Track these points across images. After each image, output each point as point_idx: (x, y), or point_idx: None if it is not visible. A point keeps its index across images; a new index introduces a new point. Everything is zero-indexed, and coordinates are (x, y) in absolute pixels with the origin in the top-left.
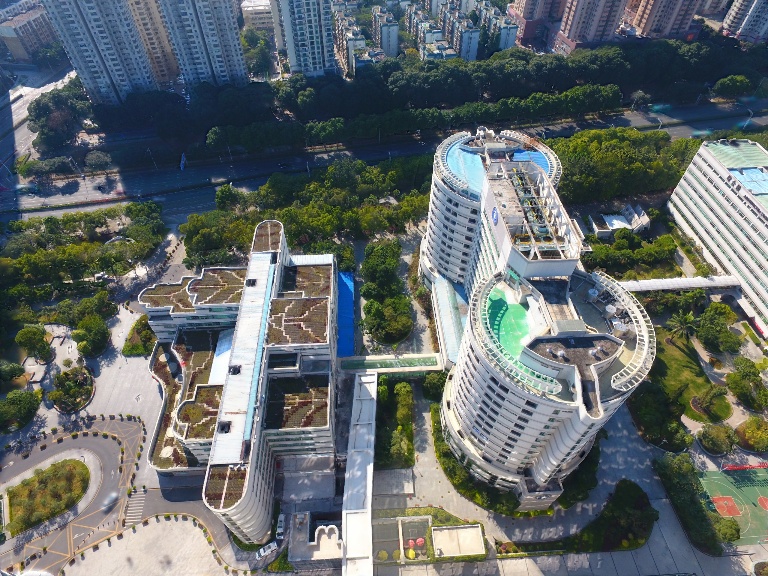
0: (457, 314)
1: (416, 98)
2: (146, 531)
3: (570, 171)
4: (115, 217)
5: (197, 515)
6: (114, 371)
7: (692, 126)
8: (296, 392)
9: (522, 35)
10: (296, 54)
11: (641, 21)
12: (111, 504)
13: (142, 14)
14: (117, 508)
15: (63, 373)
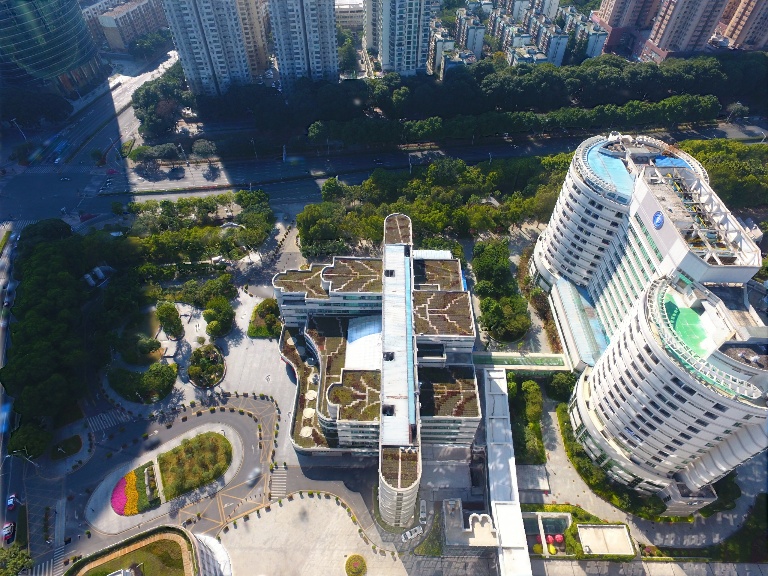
0: (584, 316)
1: (508, 101)
2: (292, 506)
3: None
4: (226, 204)
5: (339, 494)
6: (242, 351)
7: None
8: (443, 382)
9: (606, 42)
10: (390, 53)
11: (734, 32)
12: (255, 478)
13: (242, 9)
14: (261, 482)
15: (196, 350)
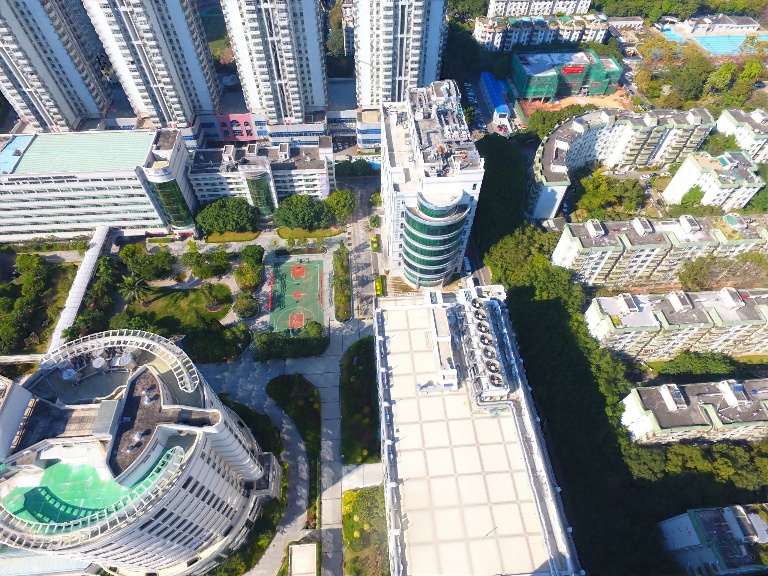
0: None
1: None
2: None
3: None
4: None
5: None
6: None
7: None
8: None
9: None
10: None
11: None
12: None
13: None
14: None
15: None
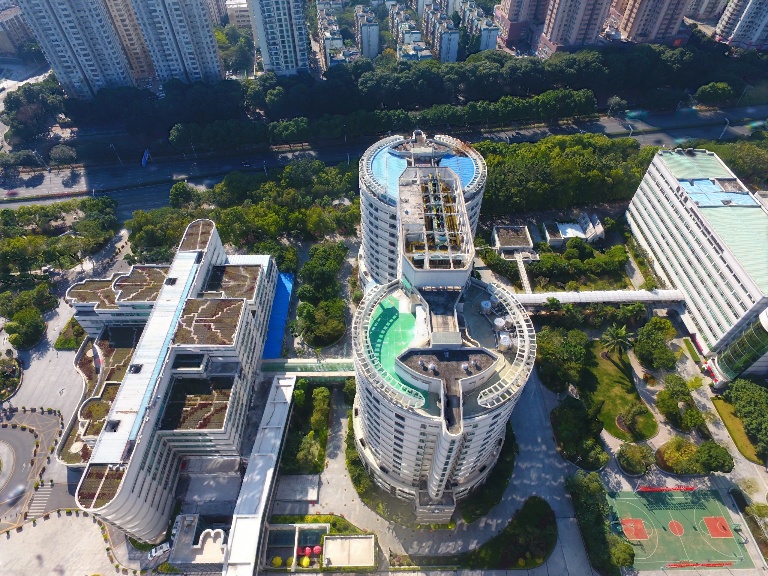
0: None
1: (386, 99)
2: (46, 525)
3: (525, 177)
4: (70, 211)
5: None
6: (43, 364)
7: (668, 134)
8: (198, 393)
9: (507, 37)
10: (269, 53)
11: (627, 25)
12: (17, 497)
13: (120, 10)
14: (22, 501)
15: None
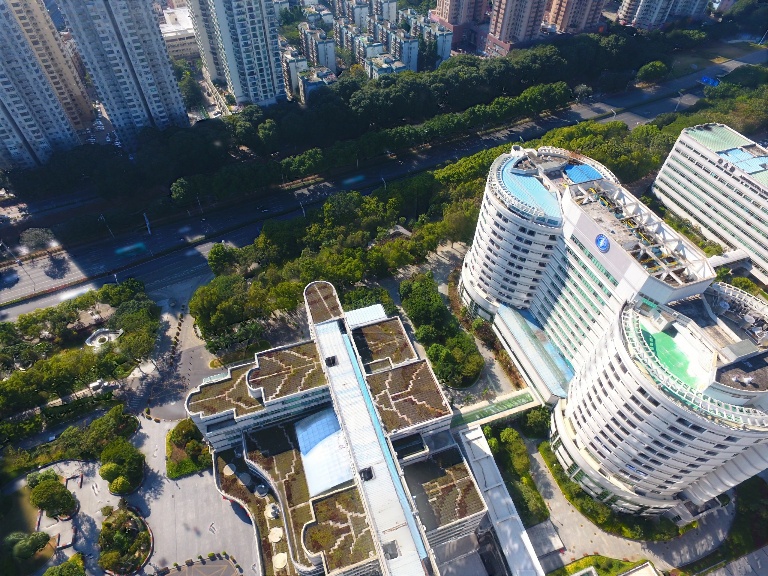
0: (538, 343)
1: (381, 116)
2: None
3: None
4: (89, 307)
5: None
6: (167, 502)
7: (632, 112)
8: (433, 478)
9: None
10: (241, 84)
11: (557, 18)
12: None
13: (42, 55)
14: None
15: (104, 525)
